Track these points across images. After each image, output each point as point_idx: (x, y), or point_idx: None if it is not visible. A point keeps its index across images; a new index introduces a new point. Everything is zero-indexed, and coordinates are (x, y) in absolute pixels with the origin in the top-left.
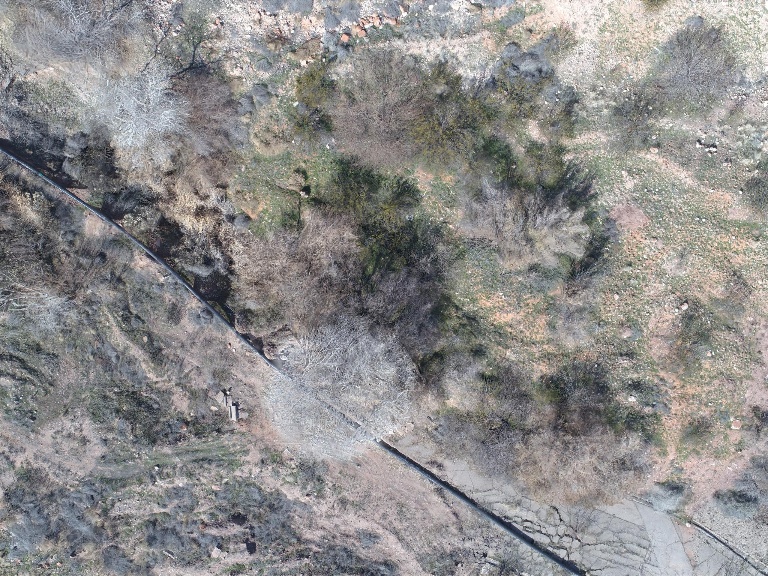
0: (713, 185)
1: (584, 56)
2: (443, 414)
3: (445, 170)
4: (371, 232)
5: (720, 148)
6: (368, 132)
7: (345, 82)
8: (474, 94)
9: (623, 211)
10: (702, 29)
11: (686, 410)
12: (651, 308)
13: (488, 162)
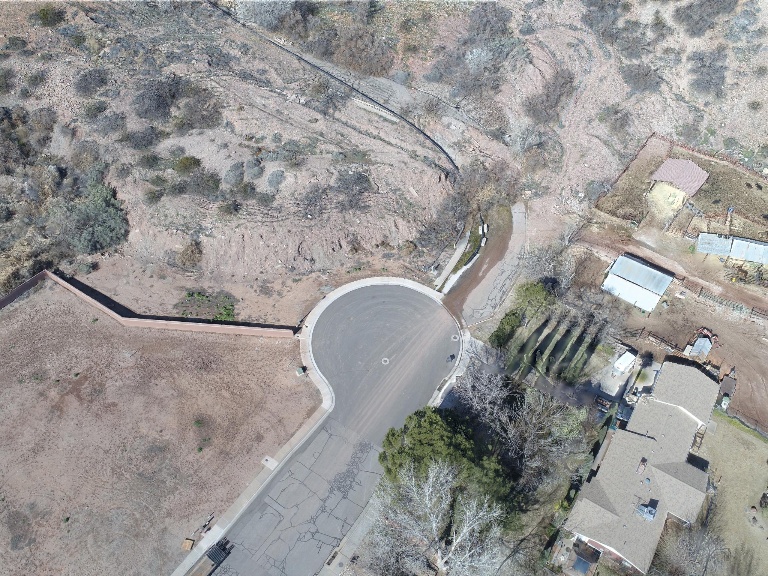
0: None
1: None
2: None
3: None
4: None
5: None
6: None
7: None
8: None
9: None
10: None
11: (406, 41)
12: None
13: None
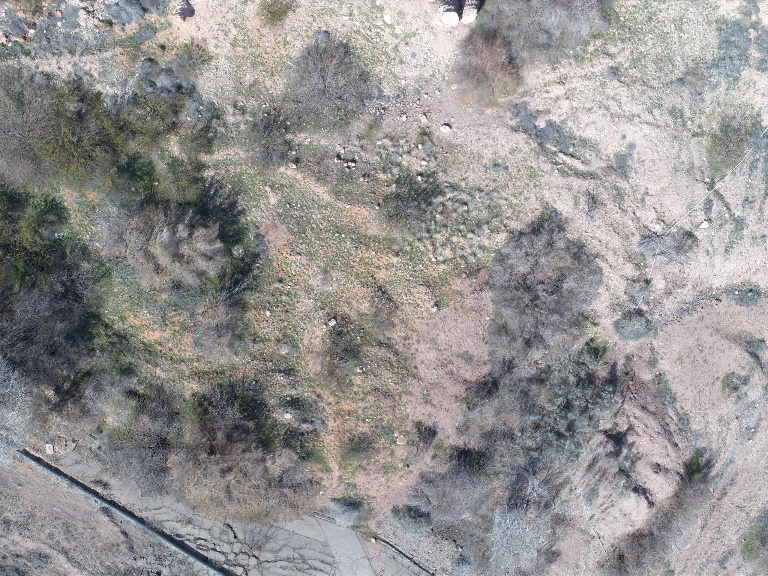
0: (349, 200)
1: (221, 71)
2: (106, 433)
3: (89, 187)
4: (9, 251)
5: (359, 163)
6: (7, 150)
7: None
8: (117, 111)
9: (269, 227)
10: (331, 43)
11: (343, 426)
12: (304, 324)
13: (130, 179)
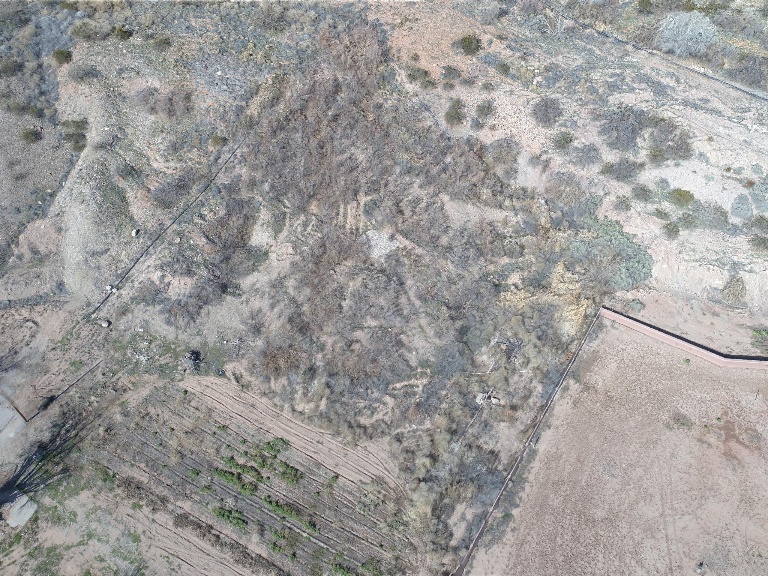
0: None
1: None
2: None
3: None
4: None
5: None
6: None
7: (655, 3)
8: None
9: None
10: None
11: None
12: None
13: None
